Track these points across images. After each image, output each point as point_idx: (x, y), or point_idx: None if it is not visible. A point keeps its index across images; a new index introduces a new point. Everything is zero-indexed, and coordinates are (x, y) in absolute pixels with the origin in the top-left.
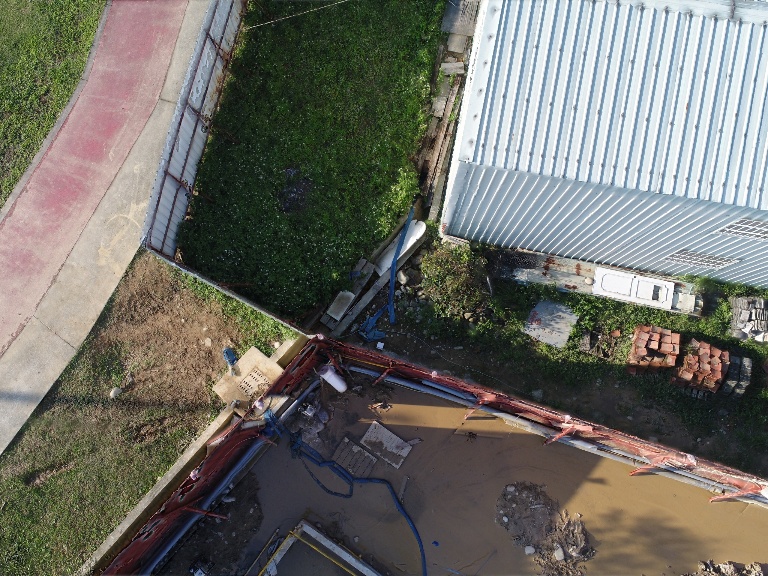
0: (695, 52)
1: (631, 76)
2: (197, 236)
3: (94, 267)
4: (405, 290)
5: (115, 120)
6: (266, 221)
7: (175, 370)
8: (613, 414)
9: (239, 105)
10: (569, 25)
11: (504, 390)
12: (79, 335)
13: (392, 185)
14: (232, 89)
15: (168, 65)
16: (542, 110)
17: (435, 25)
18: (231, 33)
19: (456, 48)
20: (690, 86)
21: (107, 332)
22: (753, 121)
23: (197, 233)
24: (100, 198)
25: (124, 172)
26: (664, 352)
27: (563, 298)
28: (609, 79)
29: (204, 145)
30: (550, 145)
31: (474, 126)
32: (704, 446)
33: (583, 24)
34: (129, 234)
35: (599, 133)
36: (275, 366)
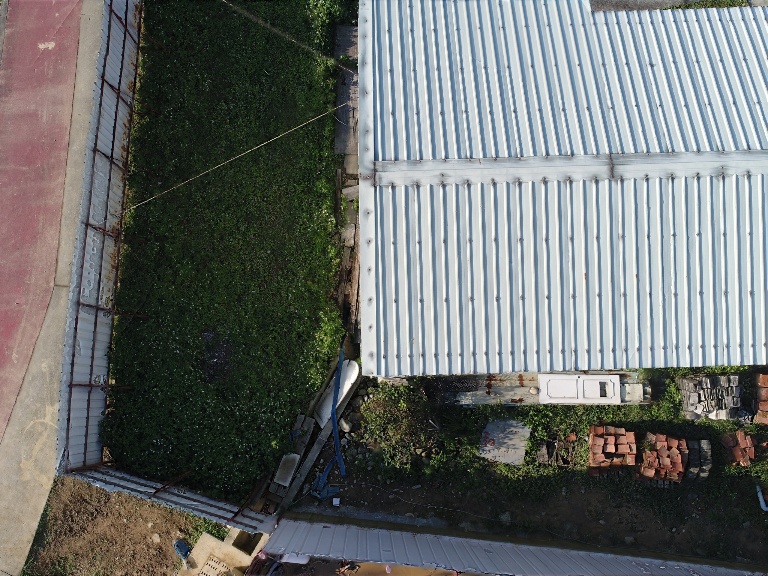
0: (582, 219)
1: (522, 255)
2: (121, 432)
3: (19, 484)
4: (350, 437)
5: (11, 318)
6: (191, 398)
7: (127, 575)
8: (585, 521)
9: (140, 277)
10: (448, 214)
11: (471, 521)
12: (17, 562)
13: (315, 331)
14: (129, 261)
15: (57, 247)
16: (438, 307)
17: (328, 150)
18: (115, 206)
19: (354, 169)
20: (584, 255)
21: (46, 551)
22: (655, 278)
23: (121, 428)
24: (11, 407)
25: (32, 373)
26: (622, 453)
27: (512, 414)
28: (500, 262)
29: (111, 329)
30: (454, 342)
31: (371, 338)
32: (680, 535)
33: (462, 210)
34: (50, 440)
35: (502, 320)
36: (231, 549)
